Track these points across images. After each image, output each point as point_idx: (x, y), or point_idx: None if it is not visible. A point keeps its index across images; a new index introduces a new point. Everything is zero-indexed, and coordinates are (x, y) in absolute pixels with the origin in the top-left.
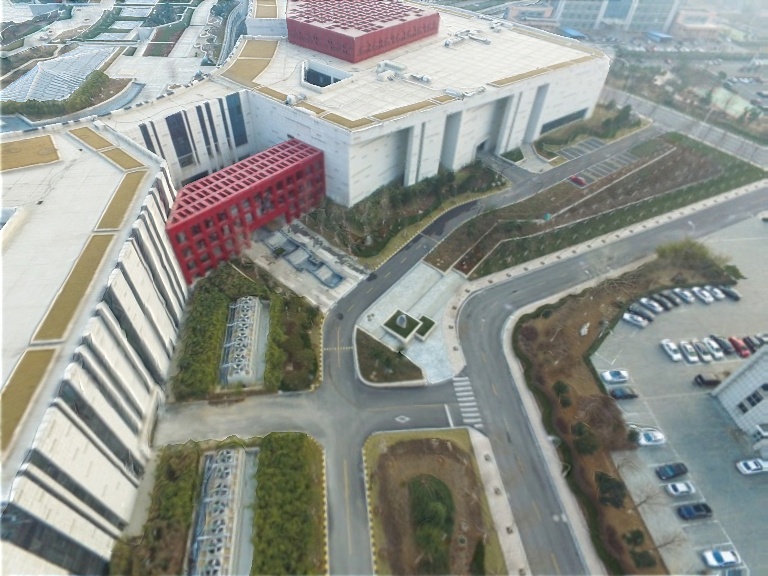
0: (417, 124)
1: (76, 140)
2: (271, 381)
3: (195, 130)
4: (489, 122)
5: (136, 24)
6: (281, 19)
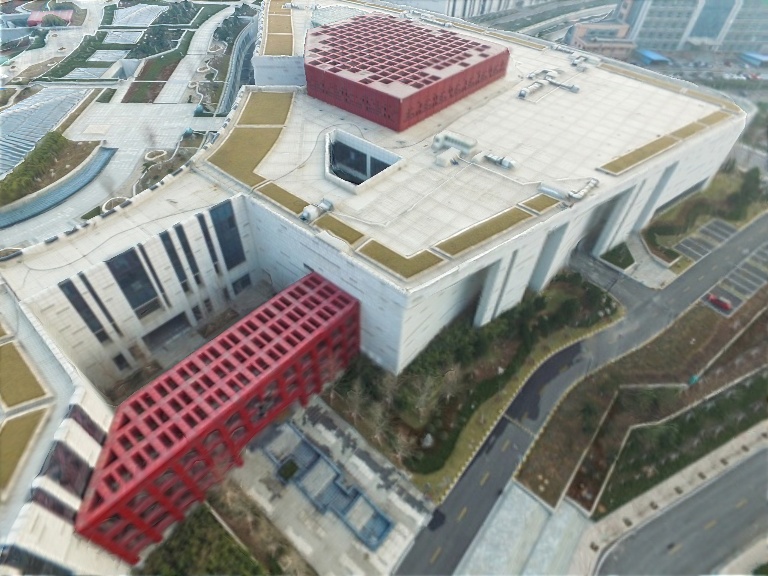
0: (506, 255)
1: None
2: None
3: (160, 266)
4: (591, 217)
5: (121, 54)
6: (298, 57)
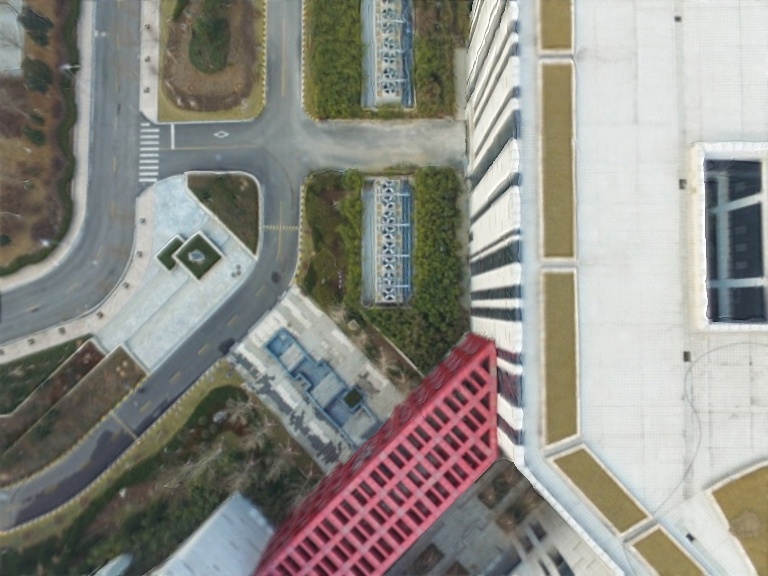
0: None
1: (713, 575)
2: (352, 171)
3: None
4: None
5: None
6: None
